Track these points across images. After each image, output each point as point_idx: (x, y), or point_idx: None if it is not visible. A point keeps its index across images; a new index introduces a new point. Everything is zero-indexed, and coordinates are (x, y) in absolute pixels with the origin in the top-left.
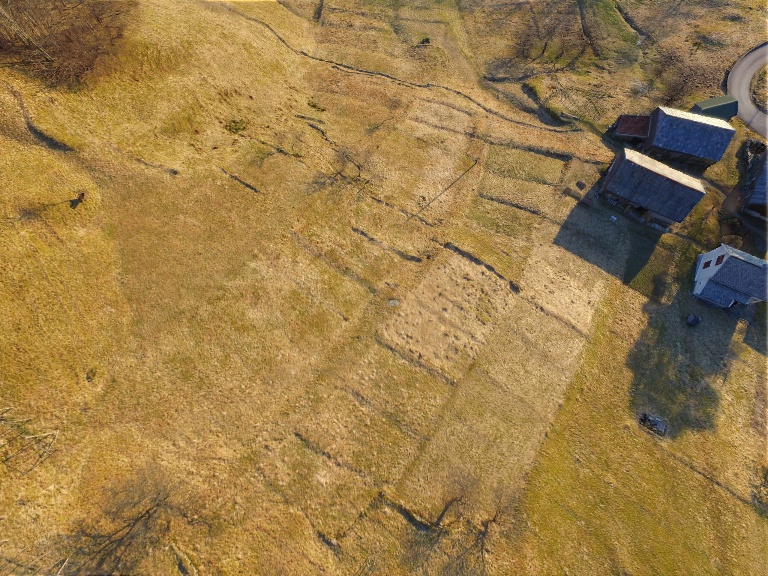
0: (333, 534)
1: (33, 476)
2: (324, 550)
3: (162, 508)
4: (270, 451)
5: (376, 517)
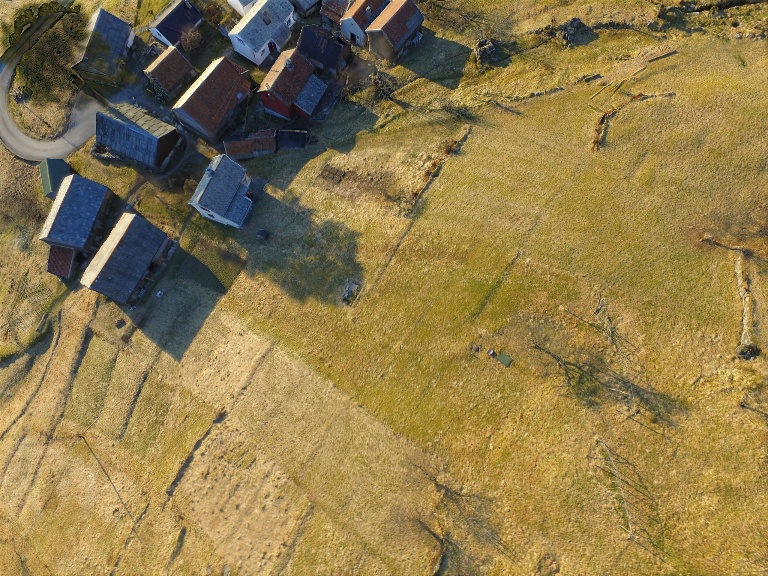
0: None
1: None
2: None
3: None
4: None
5: None
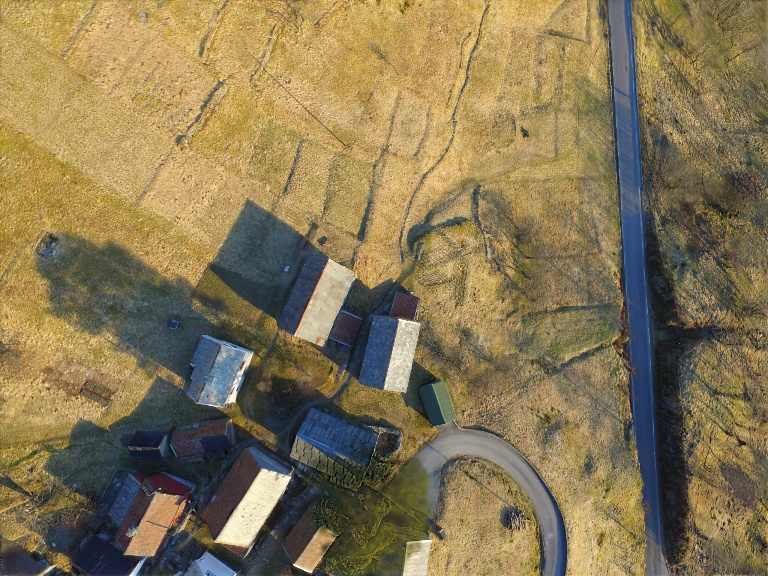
0: None
1: None
2: None
3: None
4: None
5: None
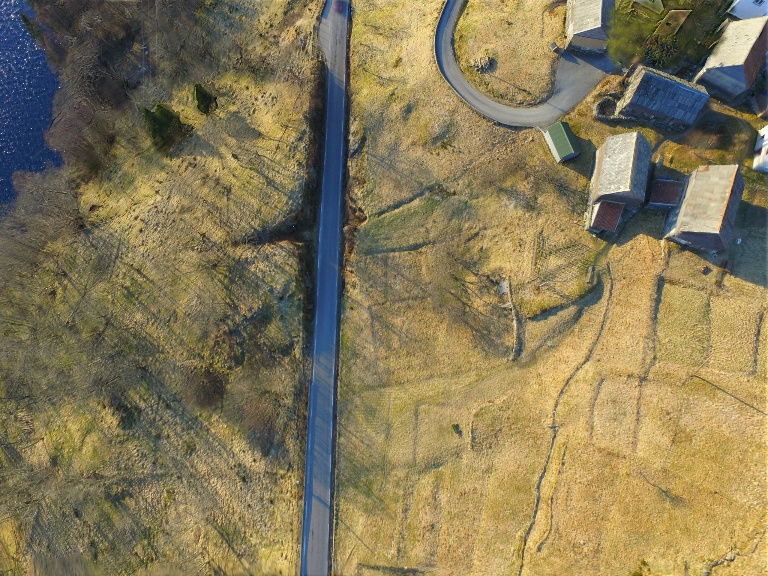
0: None
1: None
2: None
3: None
4: None
5: None
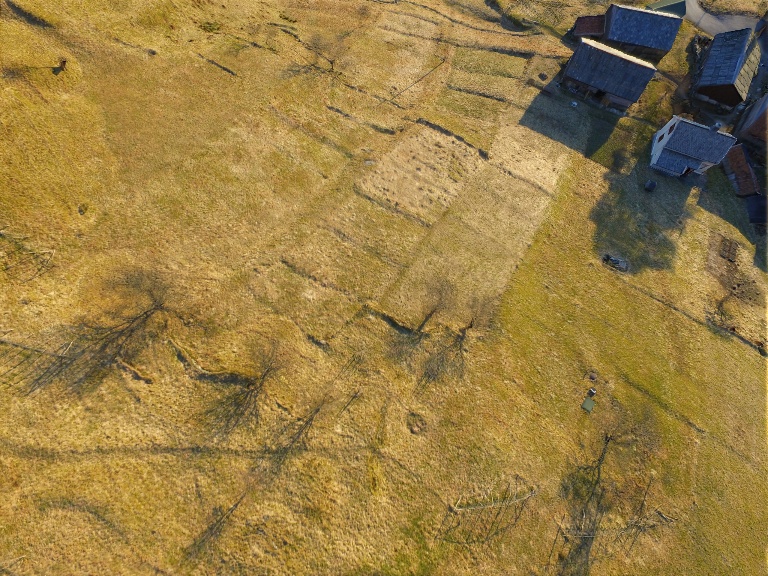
0: (322, 337)
1: (33, 285)
2: (314, 349)
3: (159, 311)
4: (259, 273)
5: (361, 323)
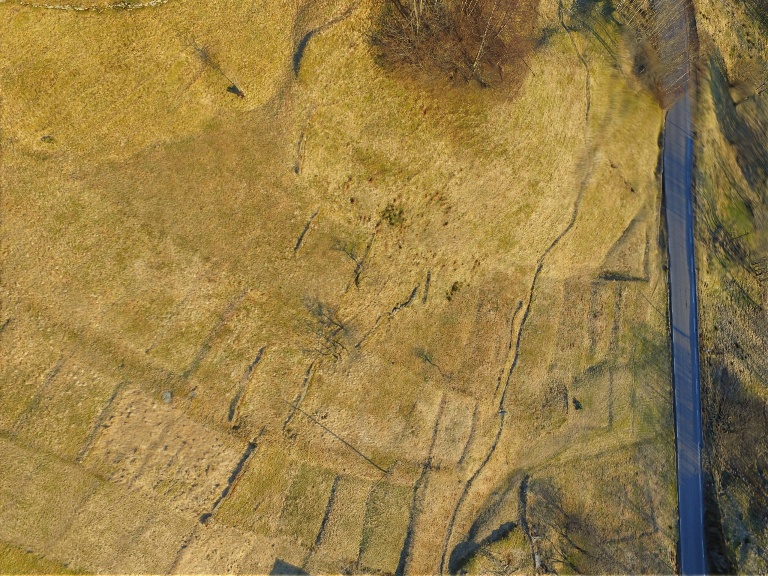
0: None
1: None
2: None
3: None
4: None
5: None
